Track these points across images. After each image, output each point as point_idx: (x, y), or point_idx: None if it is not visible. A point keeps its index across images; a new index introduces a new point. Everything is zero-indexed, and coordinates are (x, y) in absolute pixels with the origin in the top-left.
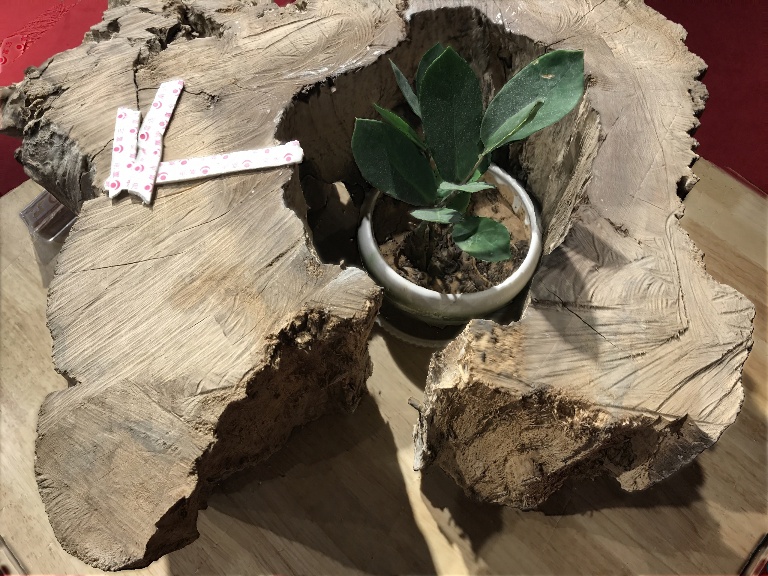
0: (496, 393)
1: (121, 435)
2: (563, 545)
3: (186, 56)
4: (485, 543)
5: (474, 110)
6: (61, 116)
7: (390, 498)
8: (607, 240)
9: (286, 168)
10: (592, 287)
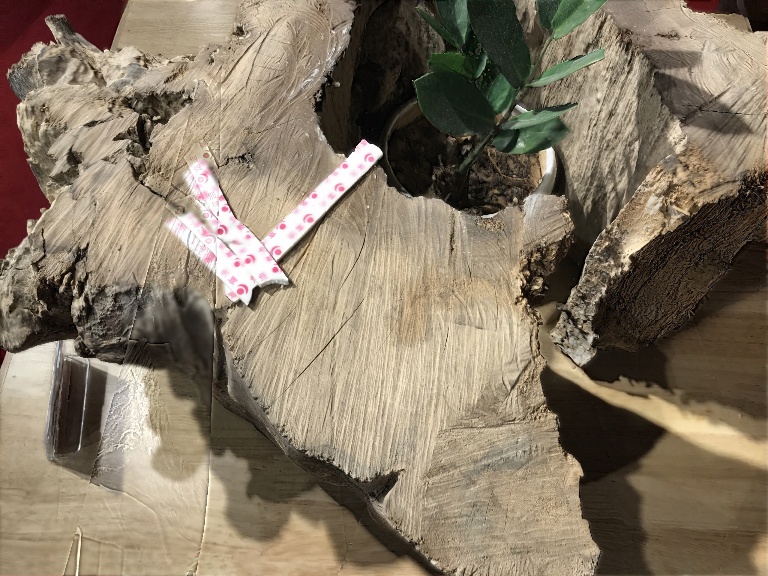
0: (717, 205)
1: (485, 477)
2: (711, 333)
3: (179, 139)
4: (666, 376)
5: (509, 11)
6: (108, 274)
7: (578, 404)
8: (673, 49)
9: (375, 169)
10: (702, 85)
